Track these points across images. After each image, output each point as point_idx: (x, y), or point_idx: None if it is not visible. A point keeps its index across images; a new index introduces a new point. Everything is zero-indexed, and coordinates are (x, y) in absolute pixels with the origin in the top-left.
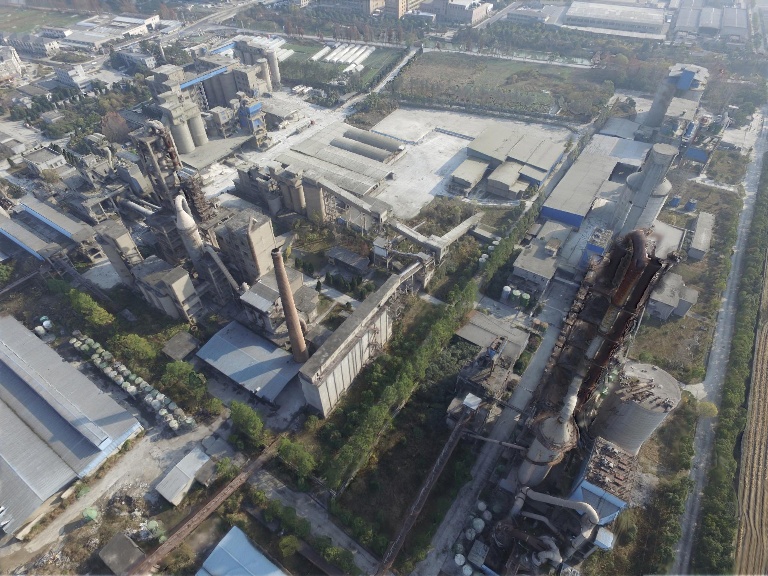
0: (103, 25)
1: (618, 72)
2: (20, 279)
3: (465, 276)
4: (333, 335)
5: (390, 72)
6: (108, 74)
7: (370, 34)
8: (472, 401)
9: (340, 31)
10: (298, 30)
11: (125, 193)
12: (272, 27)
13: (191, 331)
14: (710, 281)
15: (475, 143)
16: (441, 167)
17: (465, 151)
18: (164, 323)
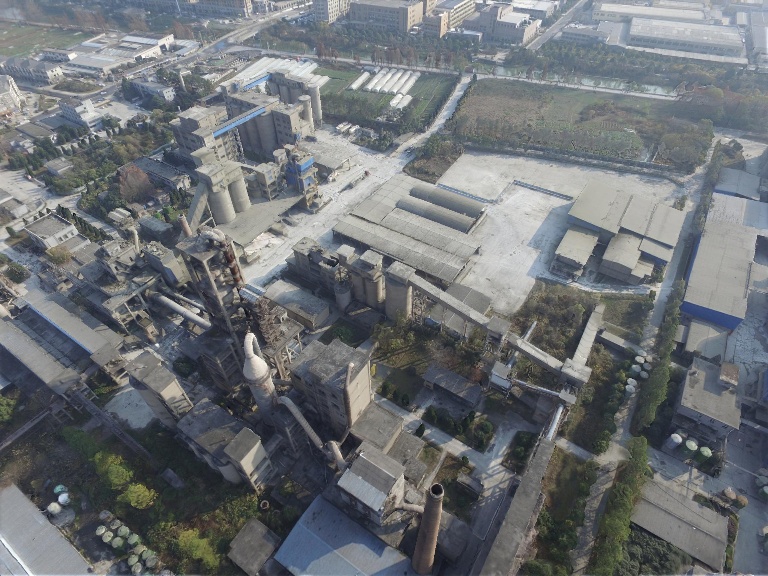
0: (111, 46)
1: (713, 108)
2: (26, 425)
3: (612, 413)
4: (488, 564)
5: (444, 105)
6: (120, 107)
7: (415, 58)
8: None
9: (380, 54)
10: (332, 52)
11: (156, 284)
12: (301, 48)
13: (261, 509)
14: None
15: (577, 208)
16: (533, 236)
17: (557, 213)
18: (221, 492)
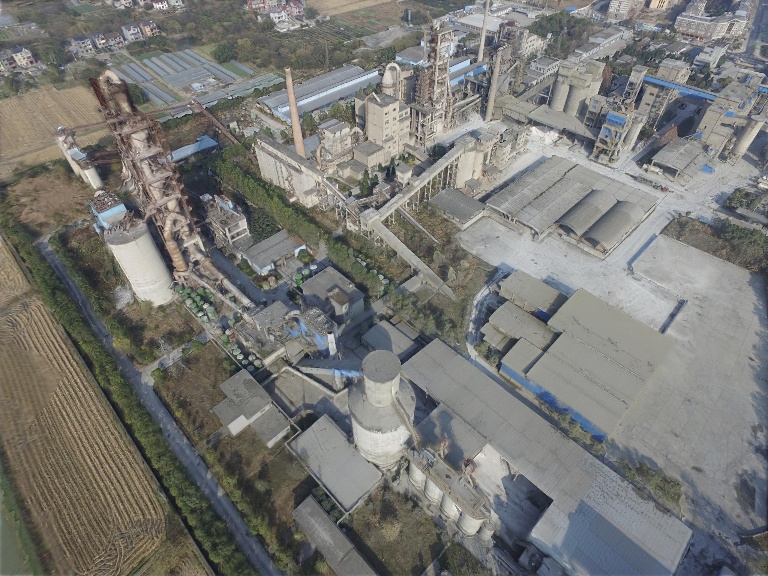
0: None
1: None
2: None
3: None
4: None
5: None
6: None
7: None
8: (206, 197)
9: None
10: None
11: None
12: None
13: None
14: (255, 498)
15: (592, 299)
16: (566, 285)
17: None
18: None
